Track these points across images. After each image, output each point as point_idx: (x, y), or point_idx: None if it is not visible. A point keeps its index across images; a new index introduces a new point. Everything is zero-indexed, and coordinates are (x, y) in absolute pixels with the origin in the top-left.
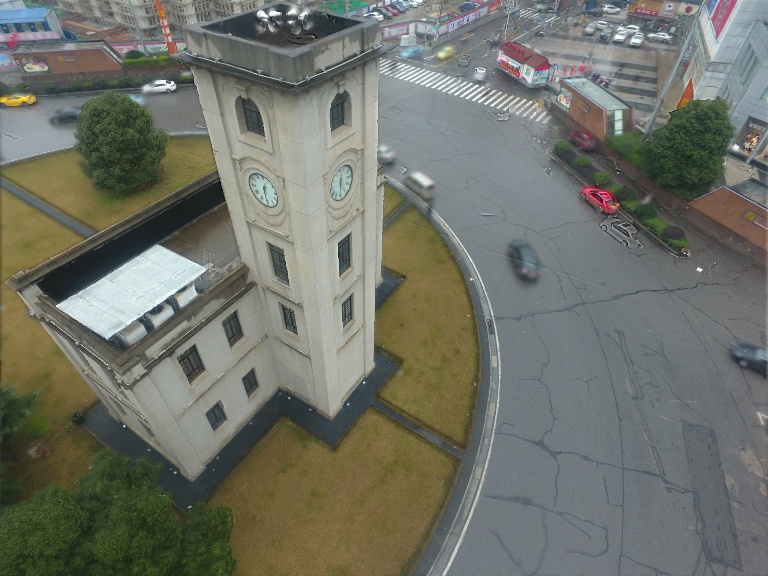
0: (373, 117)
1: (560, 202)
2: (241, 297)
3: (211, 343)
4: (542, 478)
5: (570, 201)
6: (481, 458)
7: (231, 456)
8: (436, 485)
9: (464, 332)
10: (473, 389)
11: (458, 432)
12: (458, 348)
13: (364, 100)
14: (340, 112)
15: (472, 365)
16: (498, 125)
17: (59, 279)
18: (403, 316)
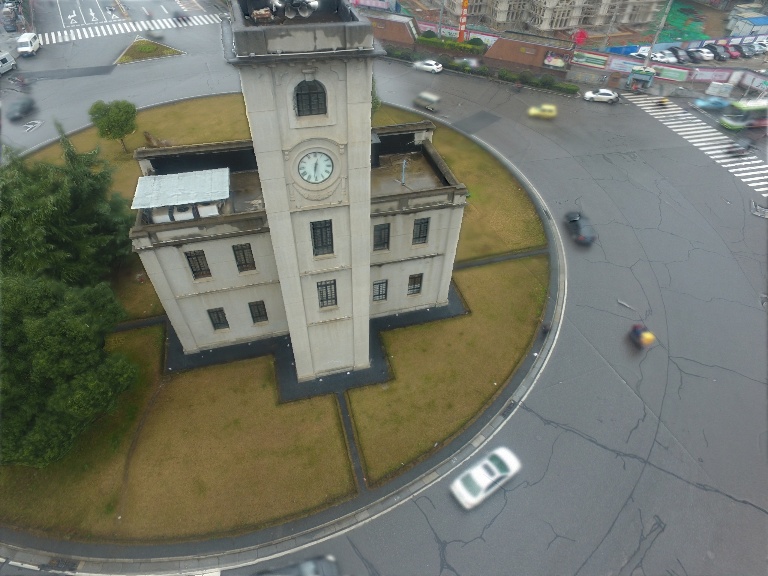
0: (363, 118)
1: (744, 341)
2: (256, 235)
3: (219, 257)
4: (410, 572)
5: (761, 347)
6: (377, 507)
7: (219, 356)
8: (319, 493)
9: (475, 394)
10: (430, 447)
11: (379, 470)
12: (453, 404)
13: (347, 97)
14: (322, 101)
15: (451, 427)
16: (749, 220)
17: (166, 164)
18: (433, 344)
